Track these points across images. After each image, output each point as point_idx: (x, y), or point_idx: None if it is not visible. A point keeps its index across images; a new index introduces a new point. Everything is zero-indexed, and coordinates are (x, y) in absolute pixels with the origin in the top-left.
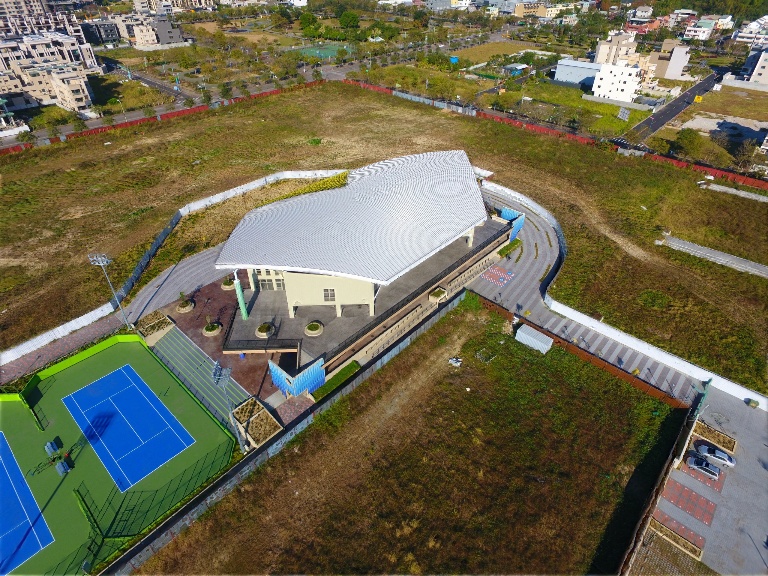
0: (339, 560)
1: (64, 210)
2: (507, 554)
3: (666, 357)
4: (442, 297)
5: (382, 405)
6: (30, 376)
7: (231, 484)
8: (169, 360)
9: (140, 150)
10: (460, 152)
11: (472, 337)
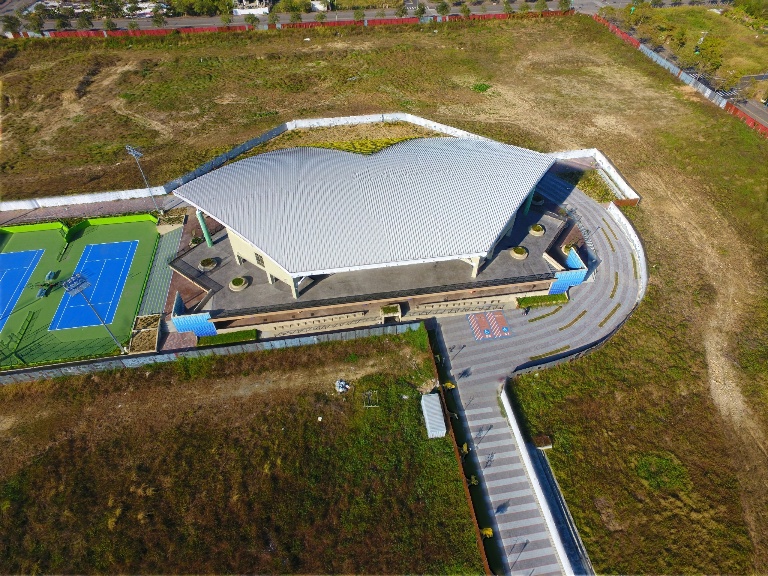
0: (86, 473)
1: (223, 94)
2: (175, 575)
3: (560, 546)
4: (391, 315)
5: (242, 382)
6: (84, 219)
7: (86, 369)
8: (160, 251)
9: (323, 53)
10: (547, 158)
11: (384, 373)
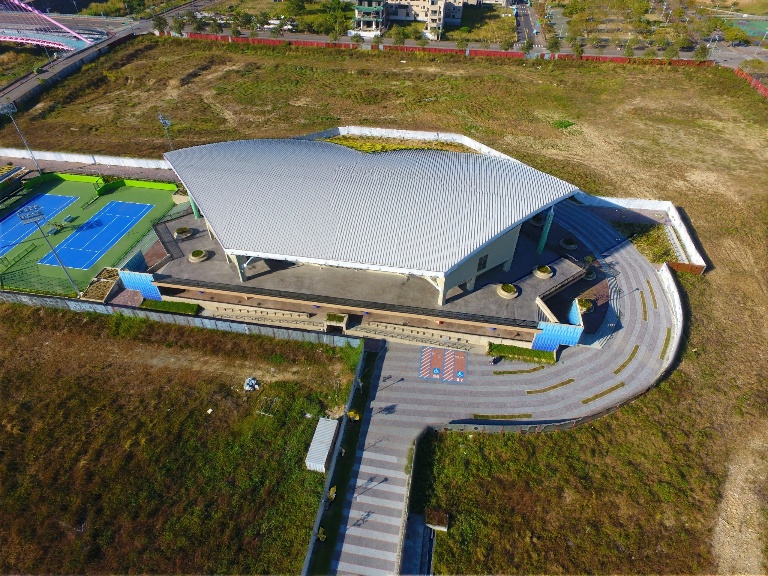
0: None
1: (300, 97)
2: None
3: None
4: (334, 324)
5: (162, 352)
6: None
7: (37, 301)
8: (165, 218)
9: (412, 74)
10: (566, 187)
11: (302, 383)
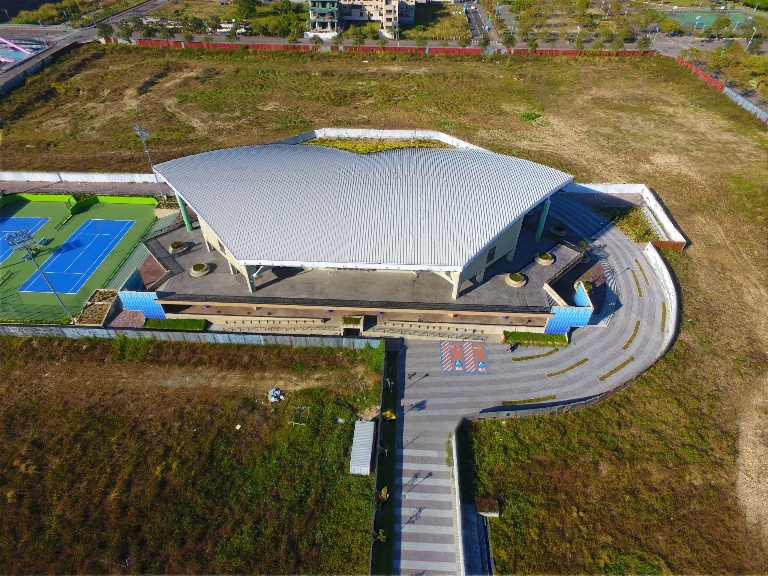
0: None
1: (268, 101)
2: (14, 570)
3: None
4: (351, 327)
5: (175, 372)
6: (94, 195)
7: (28, 332)
8: (150, 233)
9: (376, 74)
10: (562, 176)
11: (327, 389)
